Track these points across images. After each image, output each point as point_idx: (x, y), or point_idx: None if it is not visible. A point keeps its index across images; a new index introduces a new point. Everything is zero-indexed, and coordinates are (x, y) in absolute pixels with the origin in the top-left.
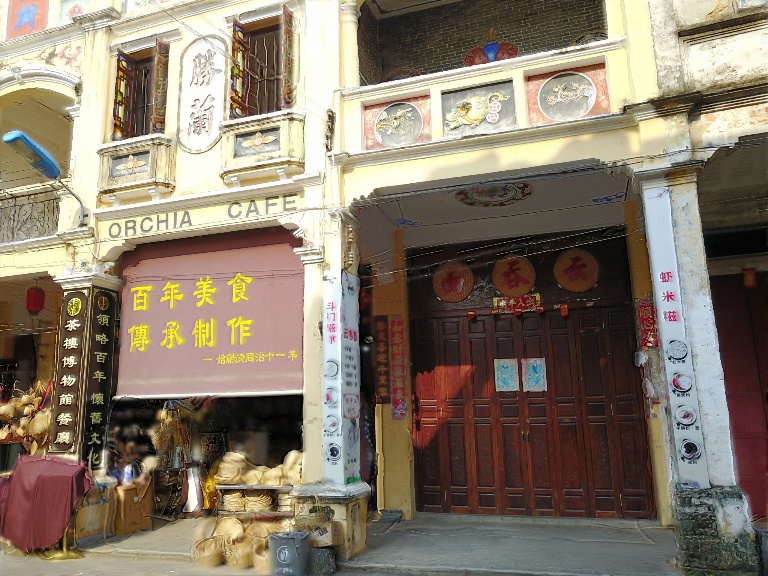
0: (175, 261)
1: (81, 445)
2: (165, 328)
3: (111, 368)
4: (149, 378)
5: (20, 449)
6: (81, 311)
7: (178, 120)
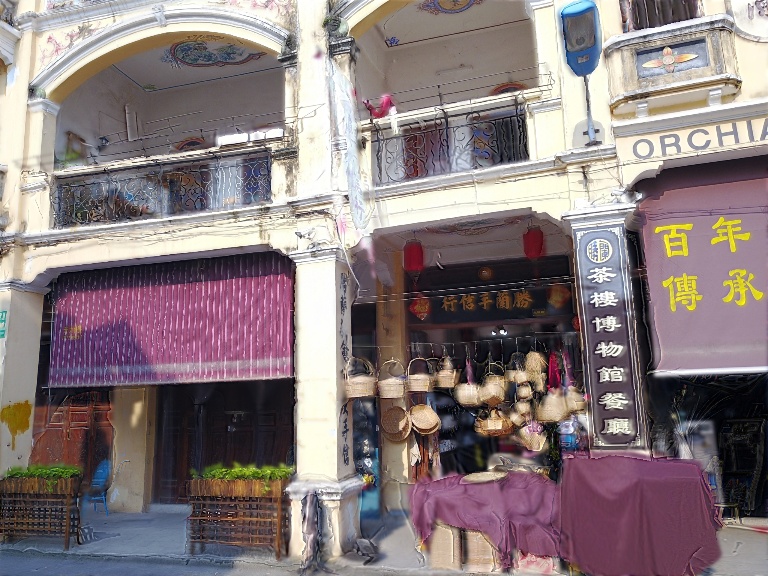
0: (729, 189)
1: (647, 436)
2: (728, 278)
3: (646, 333)
4: (714, 345)
5: (378, 443)
6: (613, 256)
7: (726, 1)
